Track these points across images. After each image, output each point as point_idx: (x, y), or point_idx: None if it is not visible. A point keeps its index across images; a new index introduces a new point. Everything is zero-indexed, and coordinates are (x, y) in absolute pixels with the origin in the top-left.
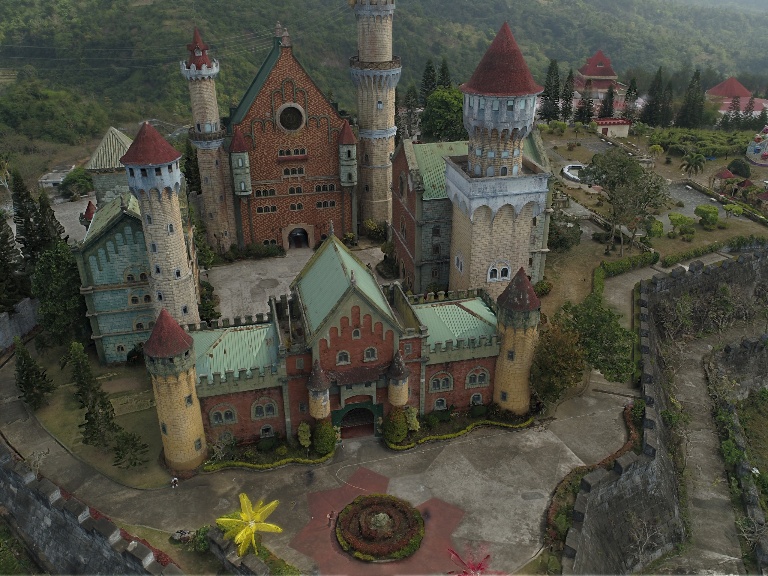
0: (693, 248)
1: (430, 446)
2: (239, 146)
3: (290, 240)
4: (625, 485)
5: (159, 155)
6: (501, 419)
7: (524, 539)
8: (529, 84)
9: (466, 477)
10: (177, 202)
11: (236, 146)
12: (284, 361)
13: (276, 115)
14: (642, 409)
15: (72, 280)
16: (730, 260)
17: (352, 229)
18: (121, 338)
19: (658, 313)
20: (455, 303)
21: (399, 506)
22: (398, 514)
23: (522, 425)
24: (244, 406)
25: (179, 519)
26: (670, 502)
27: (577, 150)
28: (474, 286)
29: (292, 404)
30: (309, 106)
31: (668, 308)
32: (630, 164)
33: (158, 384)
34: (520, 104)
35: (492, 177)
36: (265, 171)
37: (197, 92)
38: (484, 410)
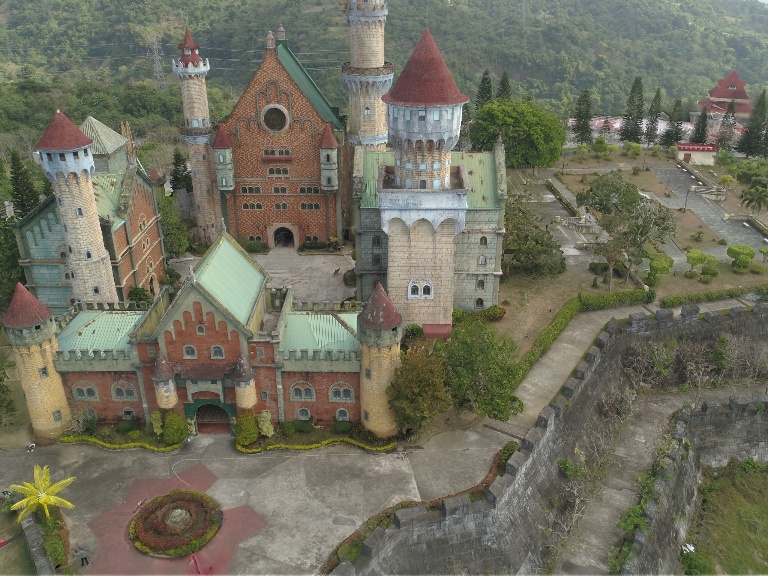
0: (706, 291)
1: (278, 454)
2: (220, 143)
3: (281, 239)
4: (453, 529)
5: (64, 142)
6: (363, 439)
7: (306, 563)
8: (446, 94)
9: (291, 490)
10: (89, 188)
11: (218, 142)
12: (135, 347)
13: (261, 115)
14: (510, 452)
15: (18, 252)
16: (740, 308)
17: (337, 233)
18: (58, 310)
19: (626, 356)
20: (332, 313)
21: (205, 506)
22: (201, 514)
23: (379, 448)
24: (104, 386)
25: (13, 481)
26: (514, 558)
27: (642, 175)
28: (394, 301)
29: (148, 391)
30: (293, 108)
31: (640, 352)
32: (626, 191)
33: (14, 353)
34: (433, 115)
35: (404, 189)
36: (251, 169)
37: (185, 89)
38: (347, 427)
